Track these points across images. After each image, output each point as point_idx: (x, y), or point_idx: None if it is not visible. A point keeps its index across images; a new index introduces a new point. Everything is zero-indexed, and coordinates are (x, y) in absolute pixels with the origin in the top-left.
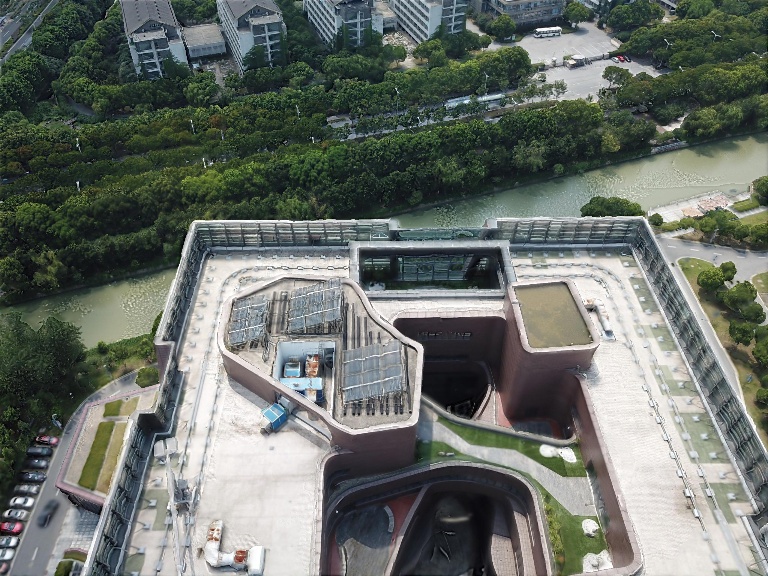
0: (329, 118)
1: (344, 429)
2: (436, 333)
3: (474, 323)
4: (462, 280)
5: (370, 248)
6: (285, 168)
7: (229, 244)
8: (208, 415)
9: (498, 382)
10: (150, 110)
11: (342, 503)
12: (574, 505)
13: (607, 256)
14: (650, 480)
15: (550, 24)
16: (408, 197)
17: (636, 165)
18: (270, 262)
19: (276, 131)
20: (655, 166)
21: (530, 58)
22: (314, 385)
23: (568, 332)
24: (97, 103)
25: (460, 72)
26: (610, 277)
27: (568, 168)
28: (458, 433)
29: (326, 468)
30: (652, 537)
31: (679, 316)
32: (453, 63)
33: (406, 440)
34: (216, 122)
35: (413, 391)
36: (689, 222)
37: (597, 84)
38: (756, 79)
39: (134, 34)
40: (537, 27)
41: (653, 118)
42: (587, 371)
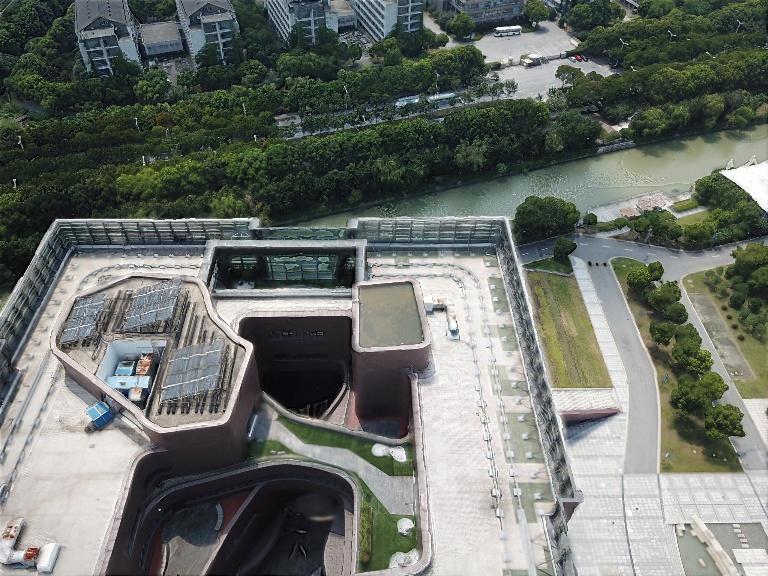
0: (279, 116)
1: (152, 428)
2: (289, 332)
3: (323, 322)
4: (332, 279)
5: (226, 247)
6: (223, 166)
7: (95, 242)
8: (36, 413)
9: (352, 381)
10: (100, 107)
11: (165, 501)
12: (394, 504)
13: (471, 256)
14: (460, 479)
15: (511, 23)
16: (347, 196)
17: (582, 165)
18: (134, 261)
19: (220, 129)
20: (603, 166)
21: (488, 57)
22: (141, 384)
23: (402, 332)
24: (46, 100)
25: (412, 71)
26: (469, 277)
27: (512, 167)
28: (294, 432)
29: (139, 466)
30: (449, 536)
31: (521, 316)
32: (407, 62)
33: (222, 439)
34: (162, 120)
35: (232, 390)
36: (623, 222)
37: (551, 83)
38: (705, 79)
39: (82, 31)
40: (497, 26)
41: (603, 118)
42: (423, 371)
